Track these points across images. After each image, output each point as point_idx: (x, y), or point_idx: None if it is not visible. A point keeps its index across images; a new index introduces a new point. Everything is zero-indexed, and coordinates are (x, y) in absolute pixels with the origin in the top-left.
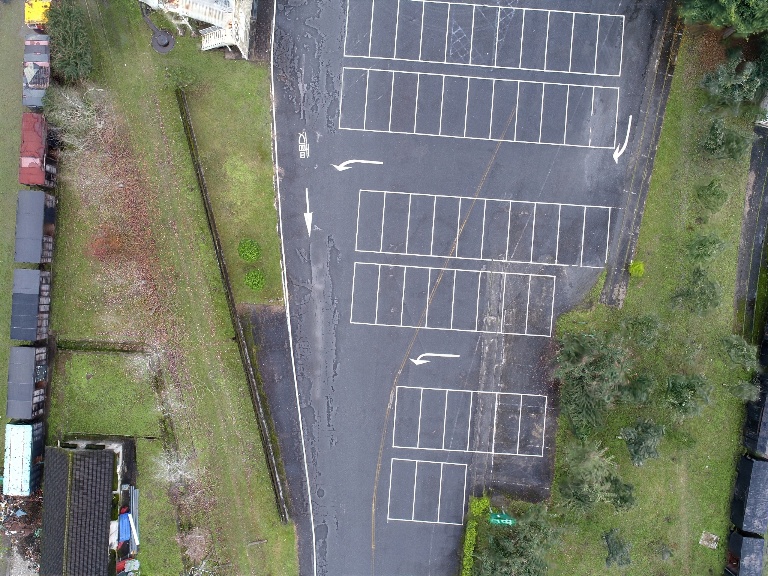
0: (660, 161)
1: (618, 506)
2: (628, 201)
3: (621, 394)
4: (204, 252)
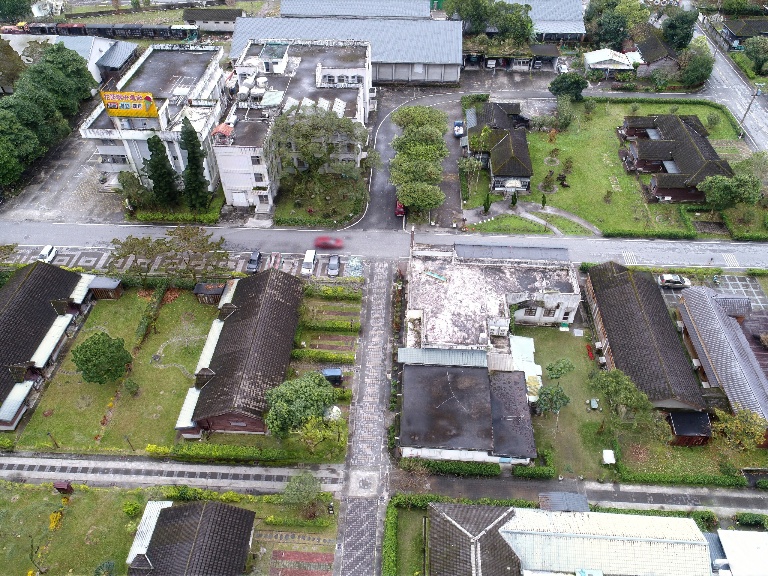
0: None
1: None
2: None
3: None
4: (132, 15)
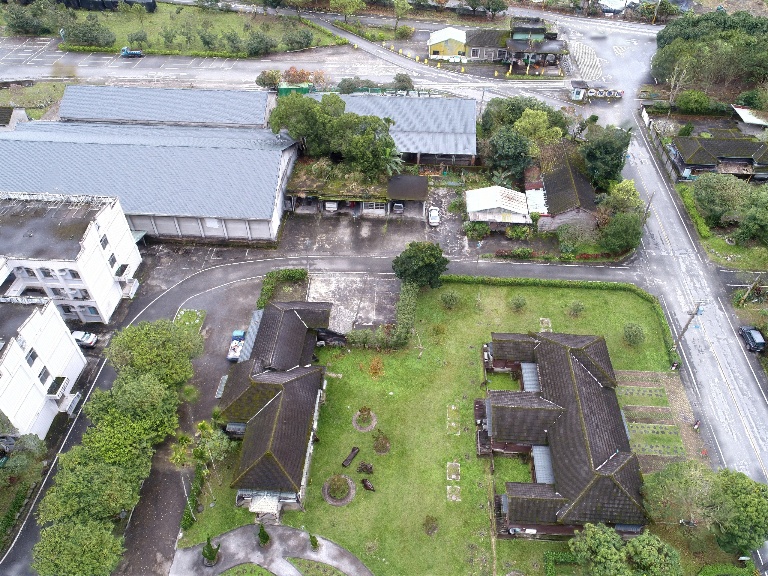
0: None
1: (70, 11)
2: None
3: (27, 8)
4: None
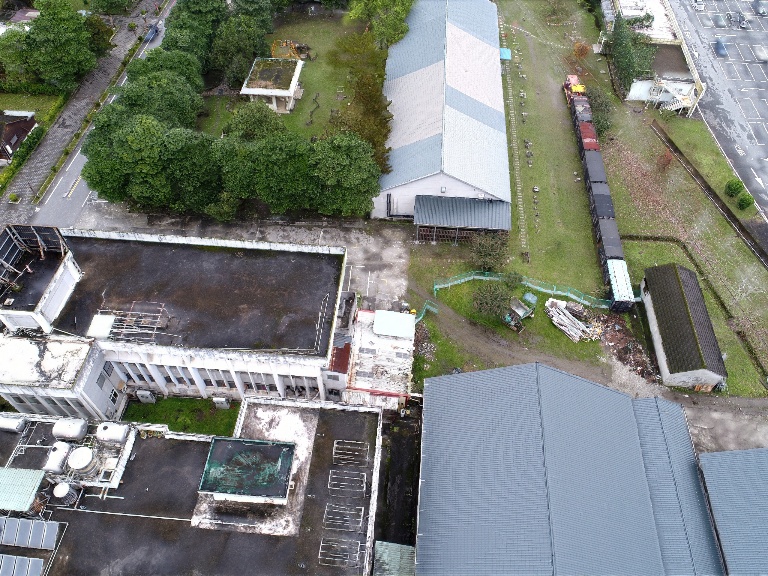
0: None
1: None
2: None
3: None
4: (697, 194)
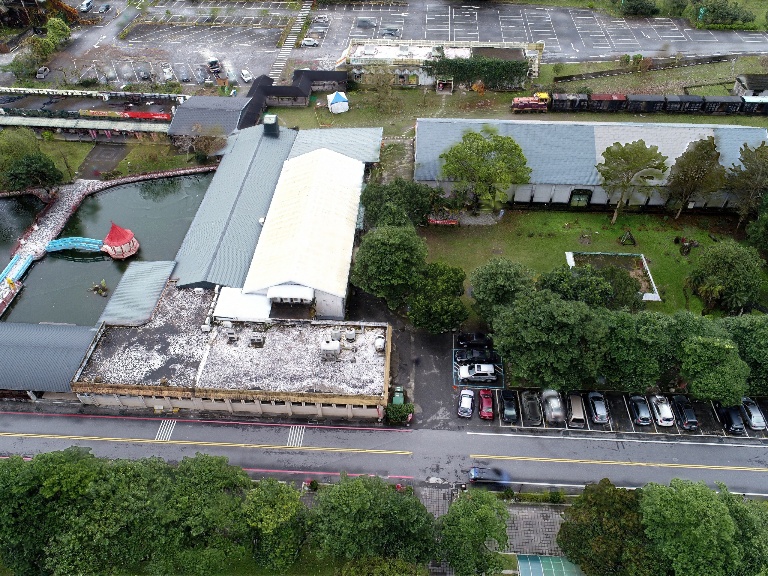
0: (549, 4)
1: None
2: (565, 8)
3: None
4: None
